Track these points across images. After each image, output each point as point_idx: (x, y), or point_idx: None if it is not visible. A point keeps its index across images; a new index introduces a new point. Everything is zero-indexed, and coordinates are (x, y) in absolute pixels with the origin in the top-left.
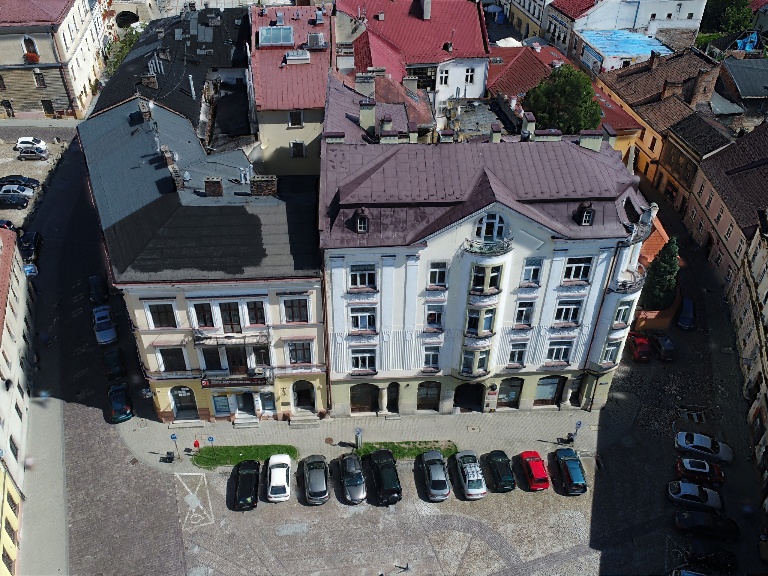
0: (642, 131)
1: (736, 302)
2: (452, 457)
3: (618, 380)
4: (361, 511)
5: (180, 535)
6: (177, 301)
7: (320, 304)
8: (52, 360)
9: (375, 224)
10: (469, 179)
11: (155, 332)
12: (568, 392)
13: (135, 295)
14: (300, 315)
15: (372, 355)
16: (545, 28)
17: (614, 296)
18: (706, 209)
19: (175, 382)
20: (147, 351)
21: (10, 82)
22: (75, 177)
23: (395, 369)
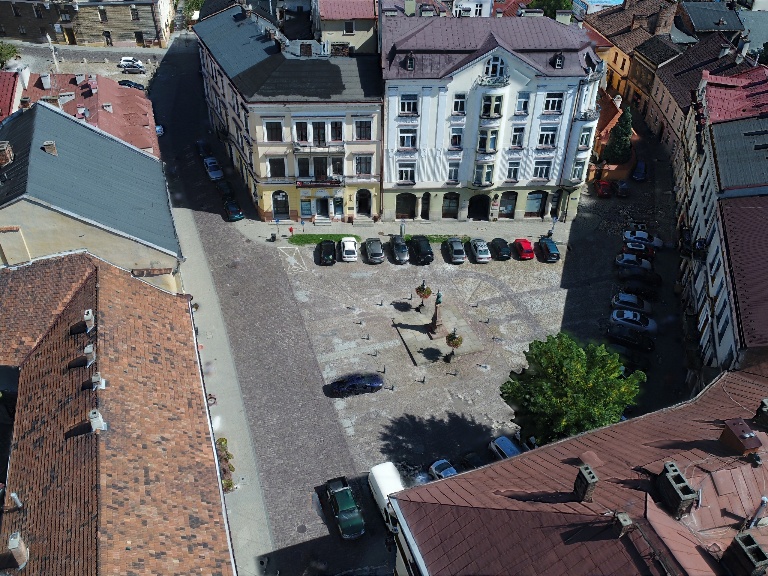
0: (615, 56)
1: (677, 162)
2: (467, 243)
3: (586, 207)
4: (406, 268)
5: (286, 276)
6: (285, 120)
7: (380, 125)
8: (179, 189)
9: (419, 65)
10: (481, 37)
11: (268, 144)
12: (549, 205)
13: (258, 114)
14: (366, 134)
15: (413, 169)
16: None
17: (579, 124)
18: (660, 104)
19: (277, 187)
20: (261, 160)
21: (111, 16)
22: (170, 85)
23: (428, 181)
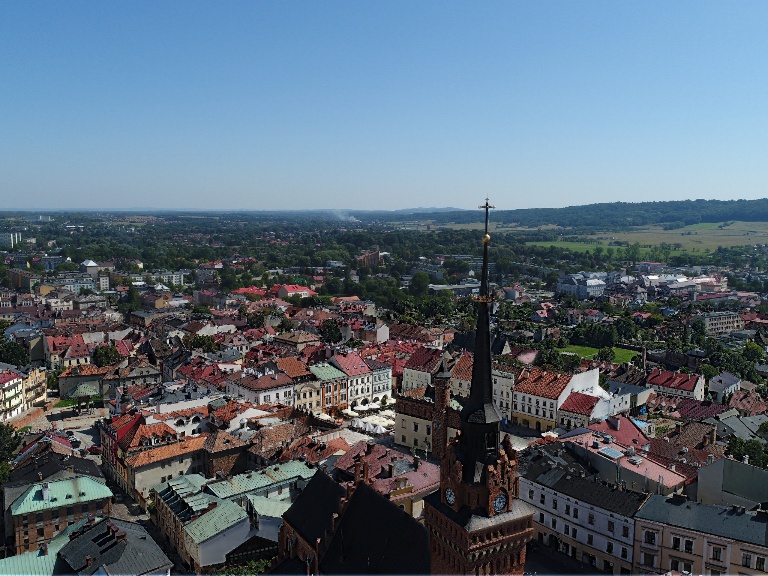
0: None
1: None
2: None
3: None
4: None
5: None
6: None
7: None
8: None
9: None
10: None
11: None
12: None
13: None
14: None
15: None
16: (558, 422)
17: None
18: None
19: None
20: None
21: None
22: (536, 567)
23: None
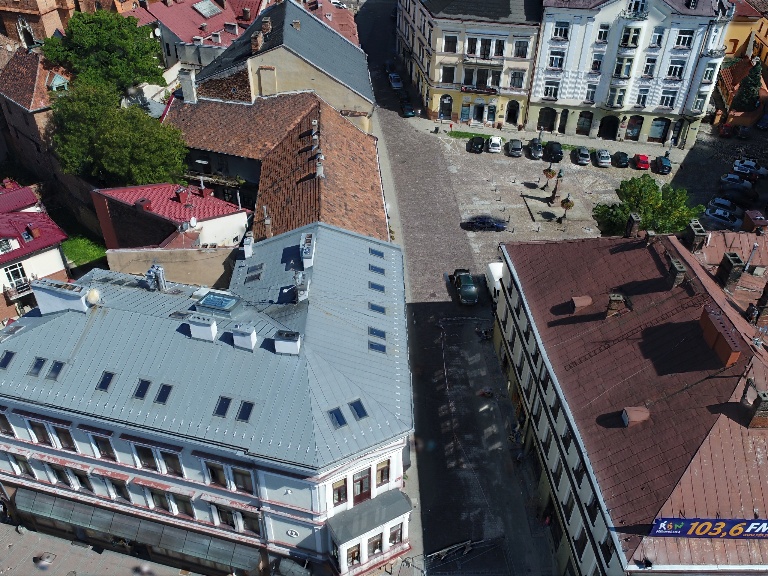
0: (767, 30)
1: None
2: None
3: (706, 142)
4: (539, 162)
5: (443, 156)
6: (461, 35)
7: (535, 46)
8: None
9: None
10: None
11: (444, 54)
12: (671, 132)
13: (440, 28)
14: (522, 53)
15: (557, 87)
16: None
17: (705, 59)
18: None
19: (445, 91)
20: (436, 67)
21: None
22: (367, 23)
23: (568, 99)
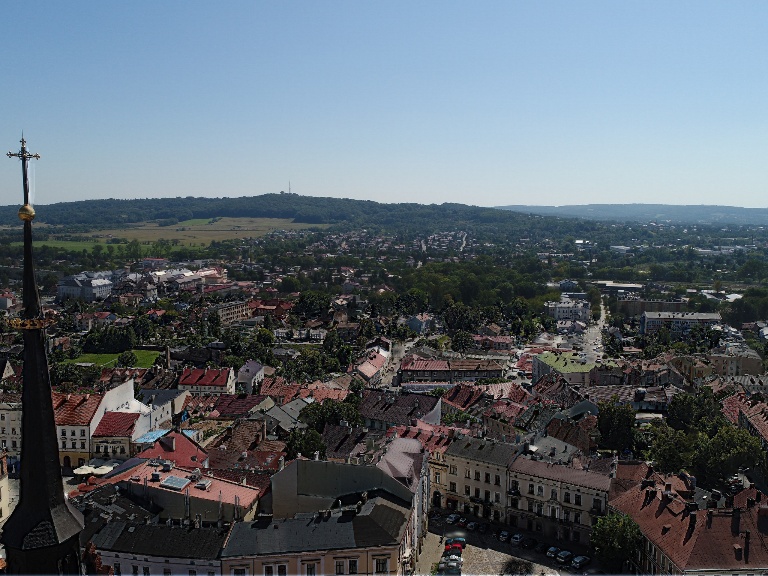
0: None
1: None
2: None
3: None
4: None
5: None
6: None
7: None
8: None
9: None
10: (405, 456)
11: None
12: None
13: None
14: None
15: None
16: (92, 452)
17: None
18: None
19: None
20: None
21: None
22: None
23: None
